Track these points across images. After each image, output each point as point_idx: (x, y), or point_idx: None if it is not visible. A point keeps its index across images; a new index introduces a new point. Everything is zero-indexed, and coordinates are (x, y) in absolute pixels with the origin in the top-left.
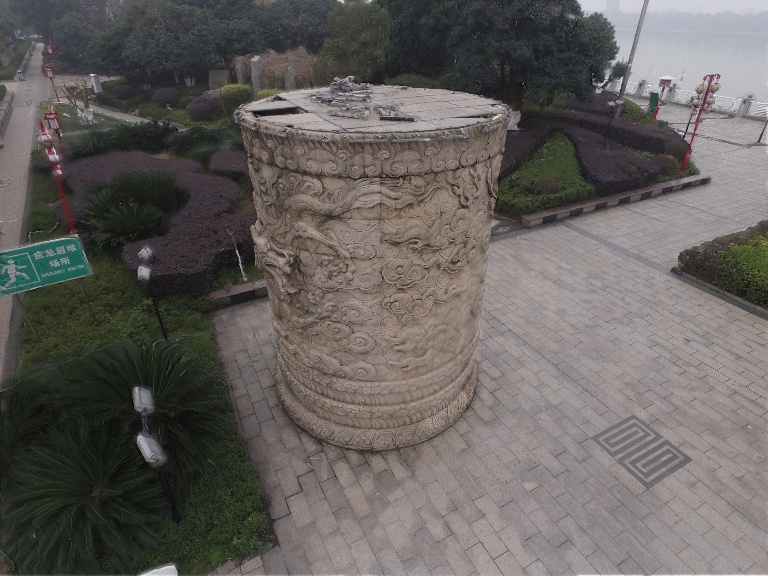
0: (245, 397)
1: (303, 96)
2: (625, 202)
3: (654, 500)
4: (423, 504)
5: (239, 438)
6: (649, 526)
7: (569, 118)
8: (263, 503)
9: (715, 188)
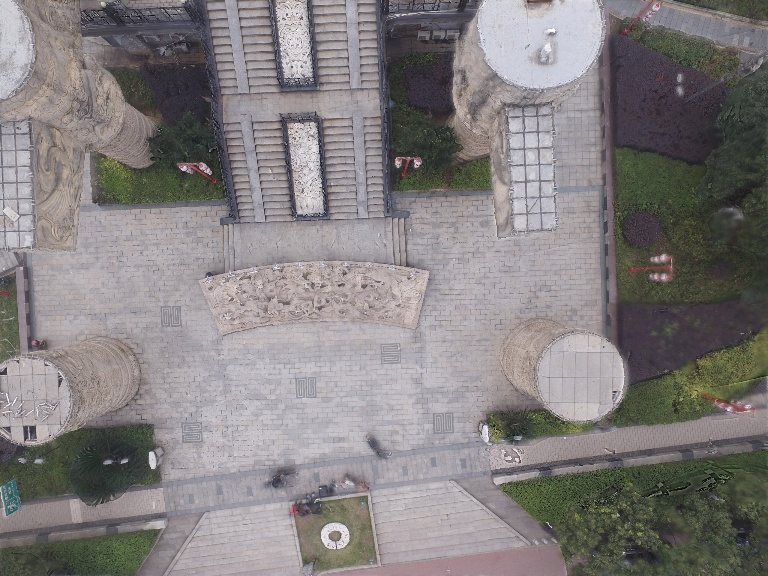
0: (98, 422)
1: (4, 419)
2: None
3: (185, 328)
4: (159, 386)
5: (117, 429)
6: (189, 336)
7: None
8: (141, 426)
9: None
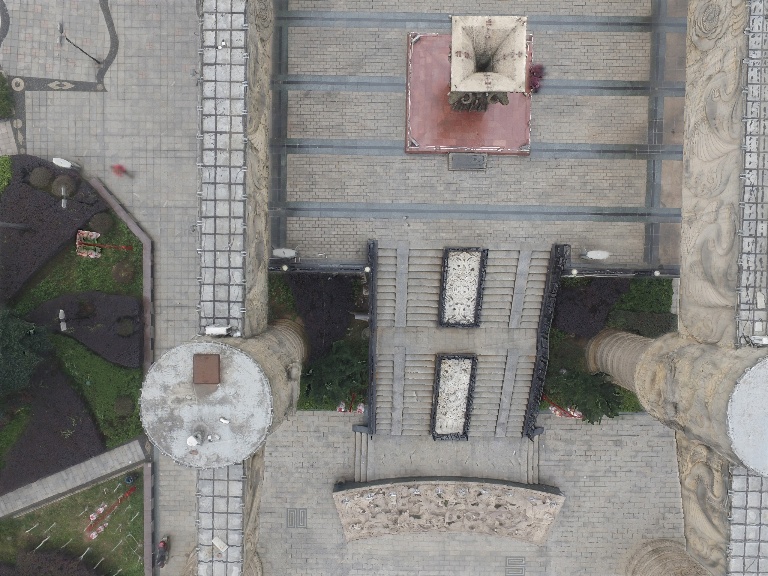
0: None
1: None
2: (153, 343)
3: (310, 530)
4: None
5: None
6: (314, 538)
7: (15, 293)
8: None
9: (163, 250)
